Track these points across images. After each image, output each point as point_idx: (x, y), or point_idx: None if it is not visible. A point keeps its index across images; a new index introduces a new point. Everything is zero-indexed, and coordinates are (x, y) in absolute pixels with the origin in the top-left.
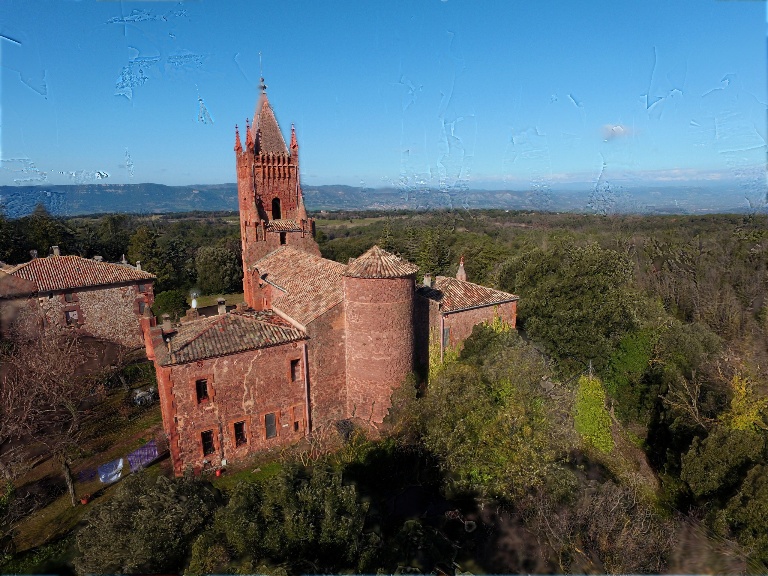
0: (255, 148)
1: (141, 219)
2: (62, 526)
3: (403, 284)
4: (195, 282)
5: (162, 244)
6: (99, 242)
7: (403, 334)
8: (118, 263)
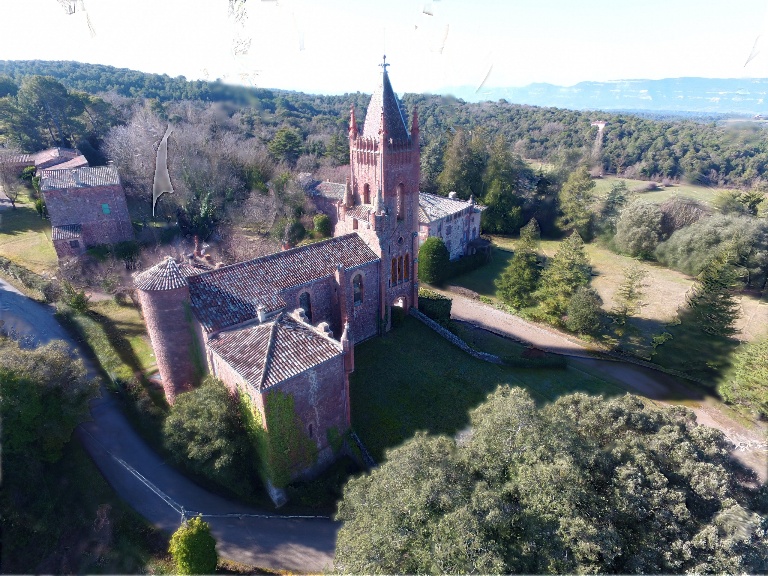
0: (360, 132)
1: (591, 157)
2: (127, 320)
3: (142, 294)
4: (614, 235)
5: (601, 186)
6: (555, 173)
7: (152, 332)
8: (462, 201)
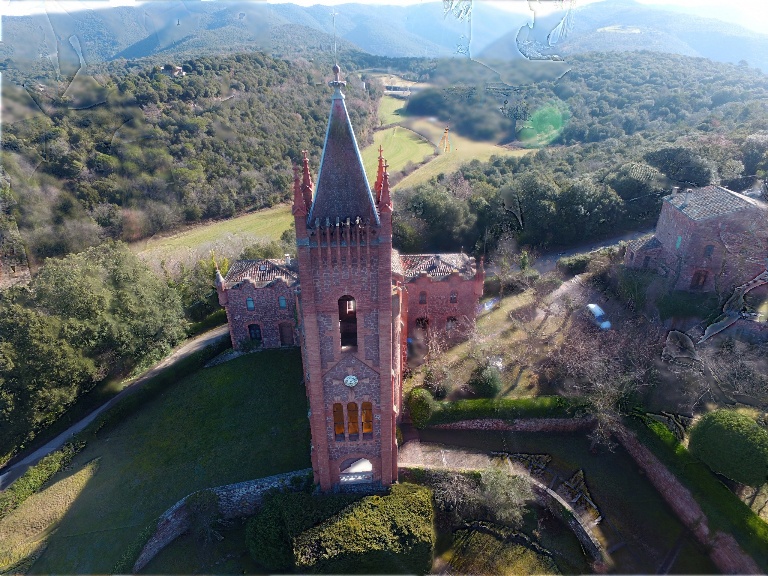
0: None
1: None
2: None
3: None
4: None
5: None
6: None
7: None
8: None
